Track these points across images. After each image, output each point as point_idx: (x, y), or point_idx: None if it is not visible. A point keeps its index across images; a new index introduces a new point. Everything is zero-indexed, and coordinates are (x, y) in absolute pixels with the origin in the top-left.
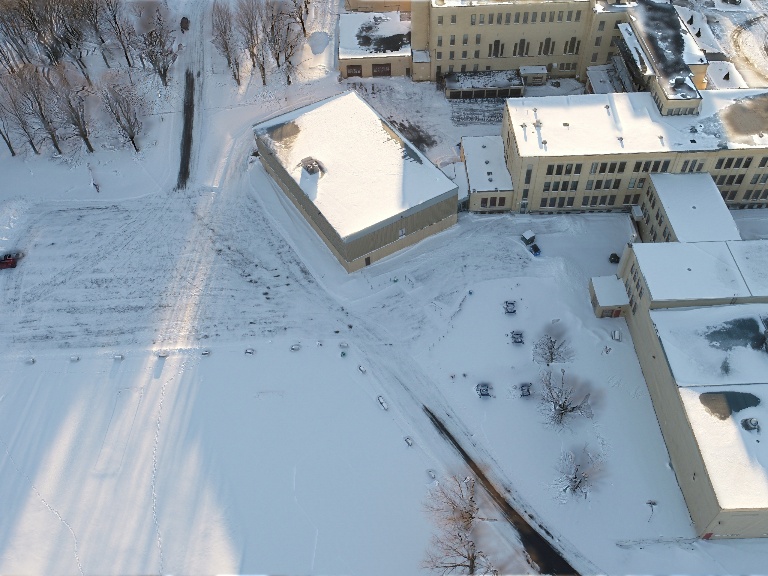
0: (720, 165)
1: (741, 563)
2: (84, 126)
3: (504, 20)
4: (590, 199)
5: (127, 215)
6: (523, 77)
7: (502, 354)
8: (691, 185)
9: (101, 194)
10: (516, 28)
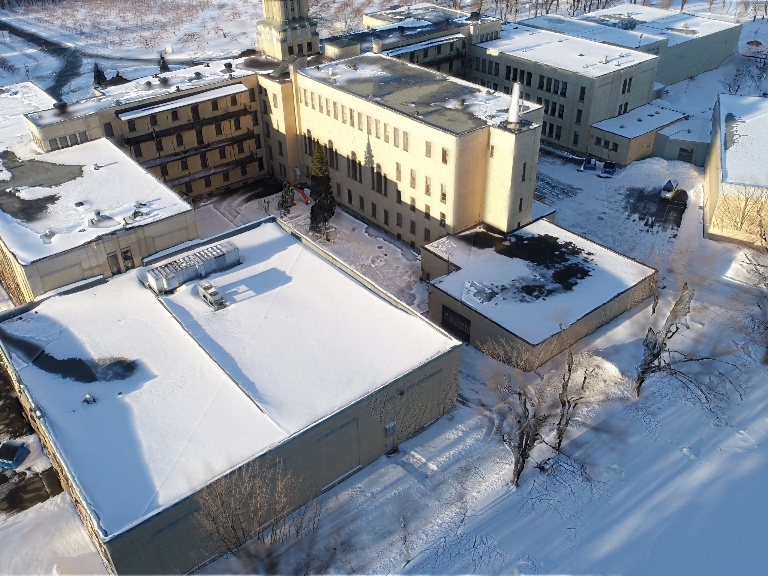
0: None
1: None
2: None
3: None
4: None
5: None
6: None
7: None
8: None
9: None
10: None
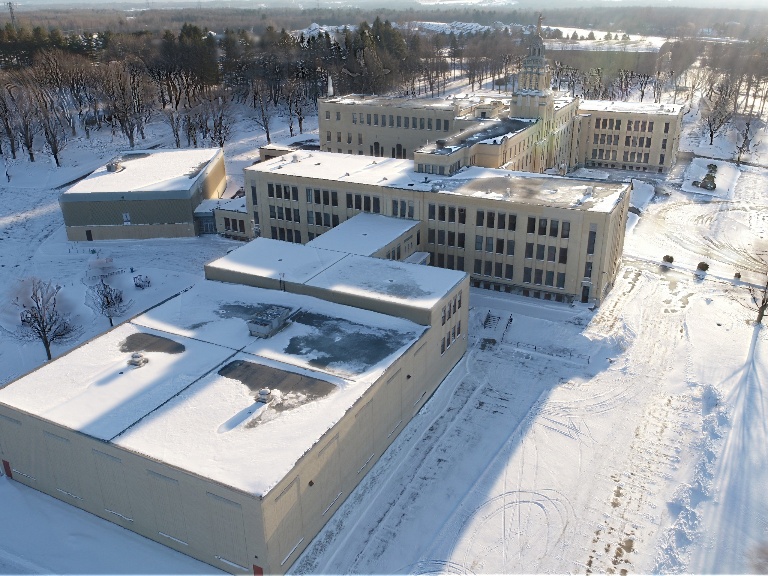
0: None
1: (8, 511)
2: (31, 139)
3: (380, 122)
4: None
5: (2, 192)
6: None
7: (85, 305)
8: (388, 223)
9: (8, 183)
10: (392, 132)
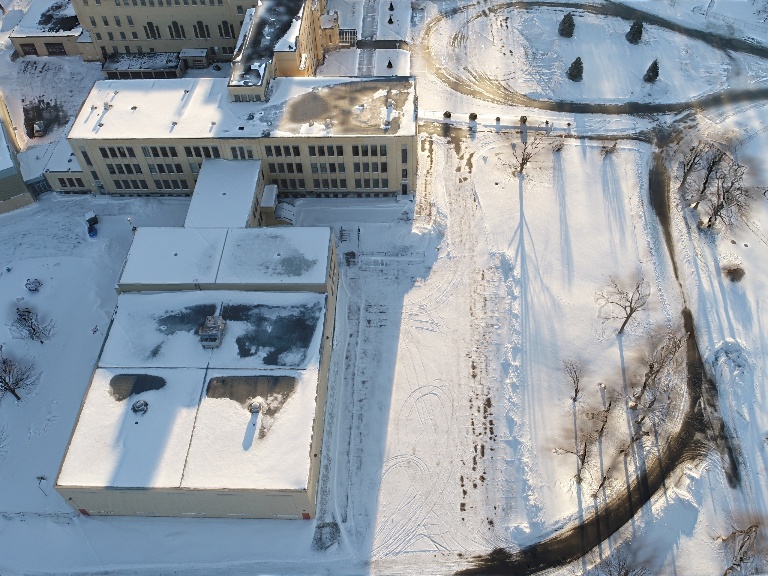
0: (271, 153)
1: (108, 539)
2: None
3: (148, 2)
4: (162, 183)
5: None
6: (183, 60)
7: (1, 330)
8: (236, 172)
9: None
10: (163, 10)
